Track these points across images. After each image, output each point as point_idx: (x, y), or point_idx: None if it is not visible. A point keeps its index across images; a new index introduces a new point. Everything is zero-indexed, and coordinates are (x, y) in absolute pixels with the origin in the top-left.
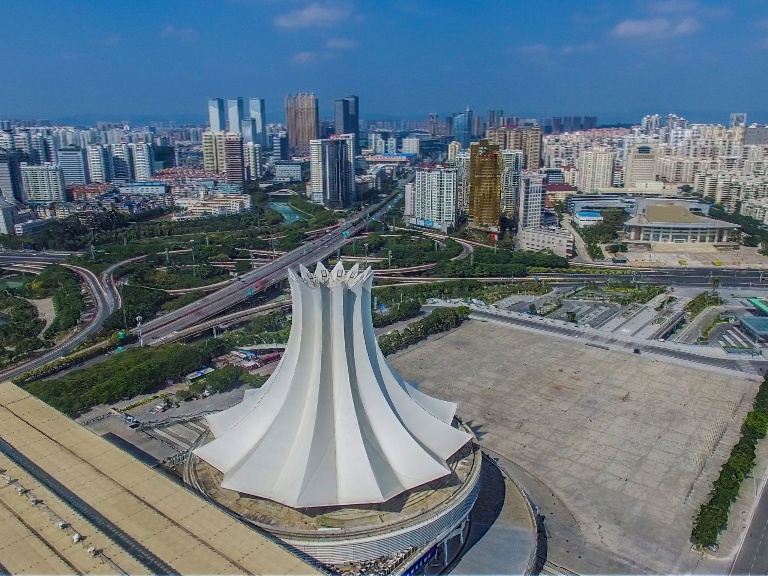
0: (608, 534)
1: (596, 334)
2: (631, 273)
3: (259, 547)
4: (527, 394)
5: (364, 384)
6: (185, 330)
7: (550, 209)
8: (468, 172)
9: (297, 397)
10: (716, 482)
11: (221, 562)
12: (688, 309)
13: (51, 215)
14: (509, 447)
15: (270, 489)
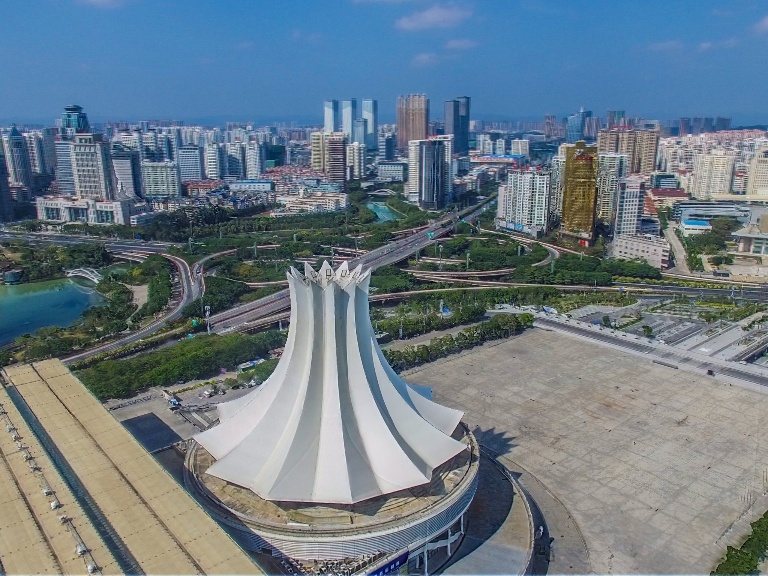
0: (618, 565)
1: (670, 351)
2: (731, 288)
3: (208, 533)
4: (572, 409)
5: (355, 384)
6: (255, 321)
7: (653, 216)
8: (563, 175)
9: (289, 392)
10: (754, 523)
11: (169, 543)
12: None
13: (164, 208)
14: (537, 462)
15: (252, 479)
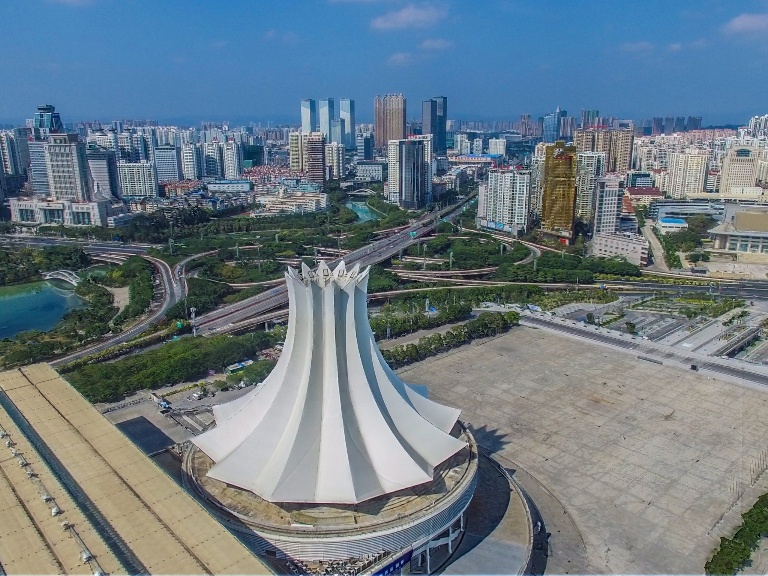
0: (615, 558)
1: (653, 347)
2: (709, 284)
3: (215, 536)
4: (562, 406)
5: (355, 384)
6: (240, 323)
7: (630, 214)
8: (542, 174)
9: (289, 393)
10: (745, 514)
11: (176, 547)
12: (765, 325)
13: (142, 209)
14: (530, 459)
15: (253, 481)
